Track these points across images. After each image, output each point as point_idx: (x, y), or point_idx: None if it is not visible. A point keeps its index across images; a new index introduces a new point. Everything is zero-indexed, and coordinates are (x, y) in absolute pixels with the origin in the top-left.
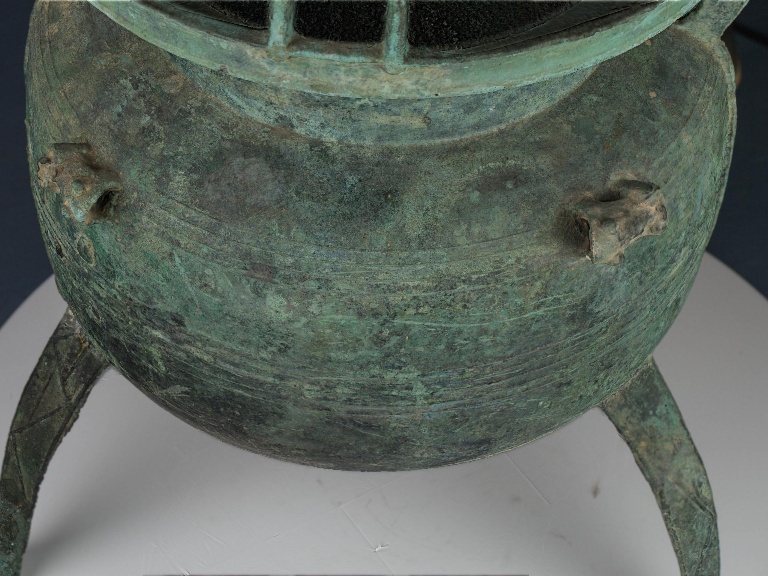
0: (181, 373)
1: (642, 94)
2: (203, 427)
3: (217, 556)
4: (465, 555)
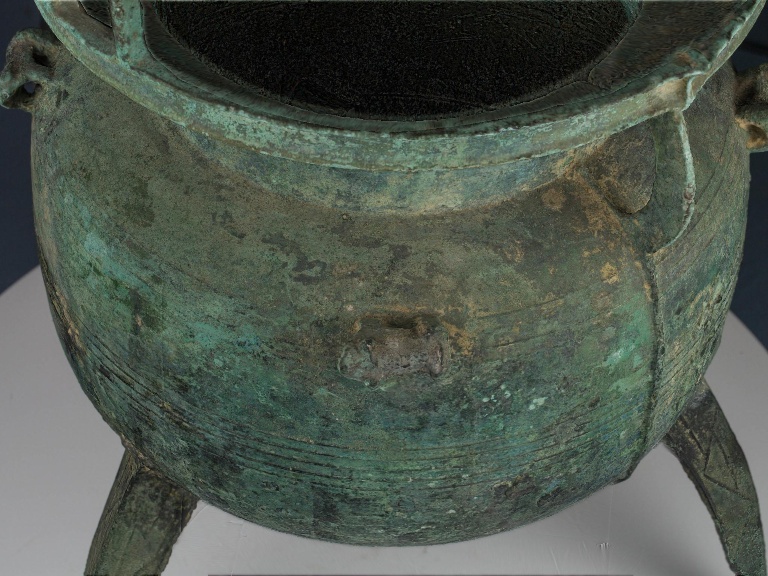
0: None
1: None
2: None
3: (566, 544)
4: None
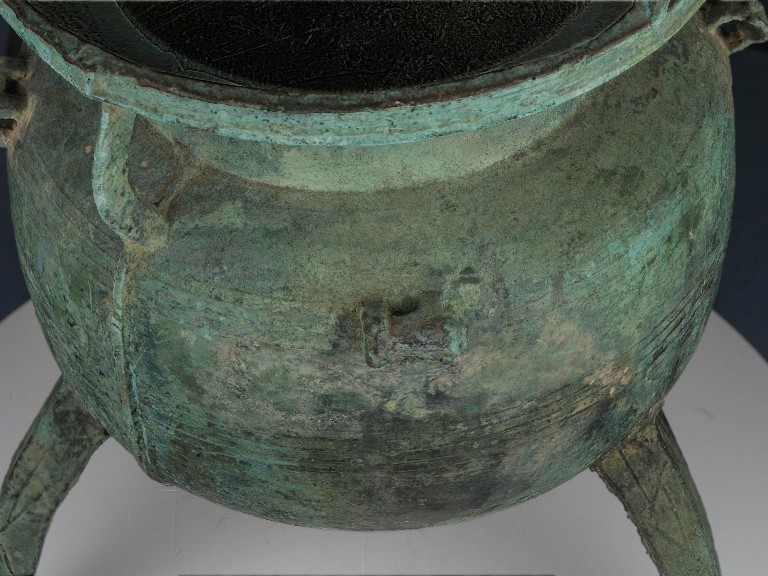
0: (234, 0)
1: (92, 138)
2: (234, 71)
3: None
4: (244, 548)
